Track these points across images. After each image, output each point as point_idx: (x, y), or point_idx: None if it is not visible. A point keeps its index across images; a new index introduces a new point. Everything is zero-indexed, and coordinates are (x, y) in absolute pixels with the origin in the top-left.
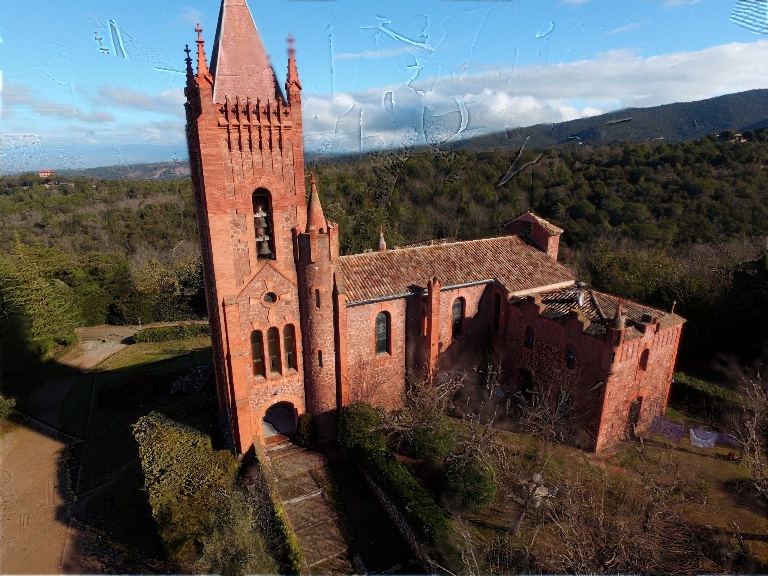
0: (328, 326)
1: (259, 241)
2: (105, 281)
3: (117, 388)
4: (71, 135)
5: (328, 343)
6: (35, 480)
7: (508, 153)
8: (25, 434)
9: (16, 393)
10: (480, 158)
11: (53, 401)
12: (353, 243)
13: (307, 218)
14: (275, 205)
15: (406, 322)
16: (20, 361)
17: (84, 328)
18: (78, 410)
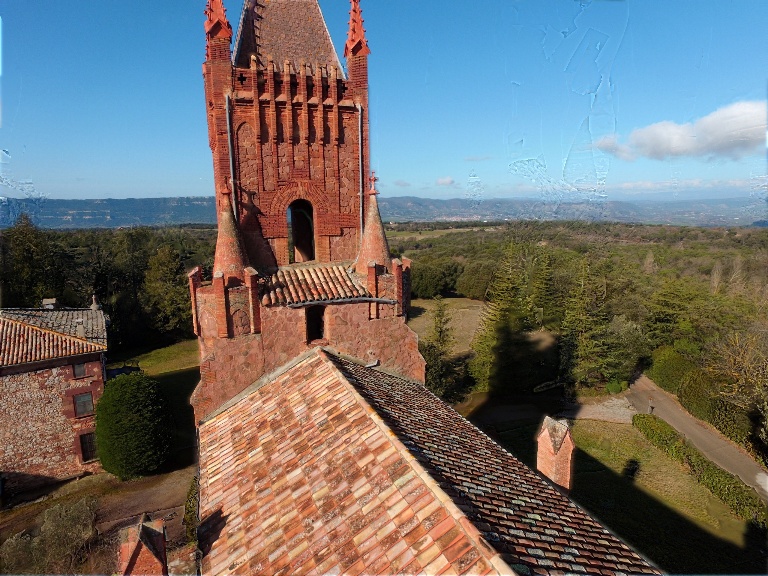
0: None
1: None
2: (703, 345)
3: None
4: None
5: None
6: None
7: None
8: None
9: (502, 398)
10: None
11: (493, 418)
12: None
13: None
14: None
15: None
16: (516, 374)
17: (657, 388)
18: None
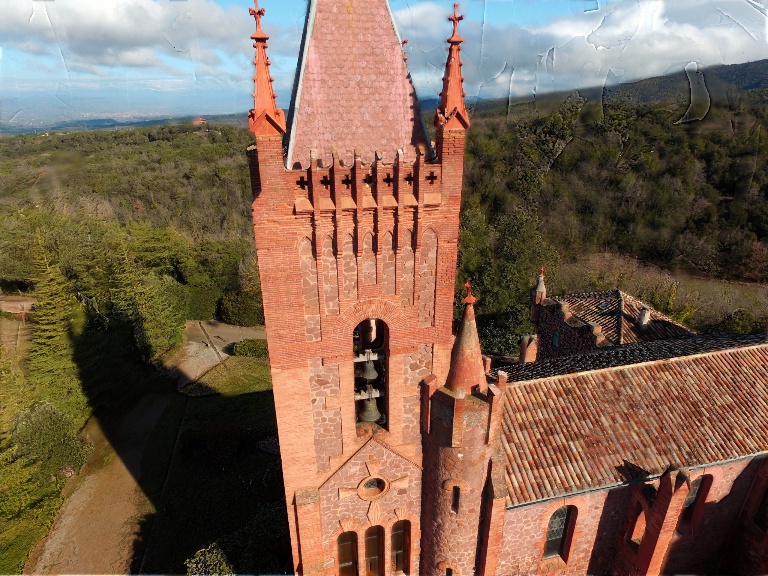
0: (468, 537)
1: (361, 399)
2: (215, 273)
3: (201, 438)
4: (191, 108)
5: (465, 560)
6: (95, 568)
7: (724, 135)
8: (104, 481)
9: (111, 411)
10: (678, 141)
11: (142, 431)
12: (493, 265)
13: (451, 363)
14: (394, 346)
15: (602, 517)
16: (116, 377)
17: (193, 321)
18: (161, 454)
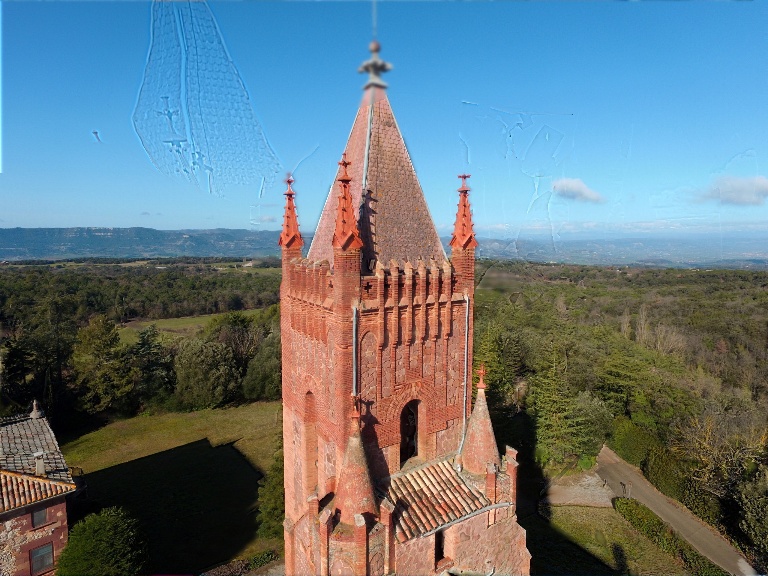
0: None
1: None
2: (659, 419)
3: None
4: (710, 245)
5: None
6: None
7: None
8: None
9: None
10: None
11: None
12: None
13: None
14: None
15: None
16: None
17: (620, 459)
18: None
